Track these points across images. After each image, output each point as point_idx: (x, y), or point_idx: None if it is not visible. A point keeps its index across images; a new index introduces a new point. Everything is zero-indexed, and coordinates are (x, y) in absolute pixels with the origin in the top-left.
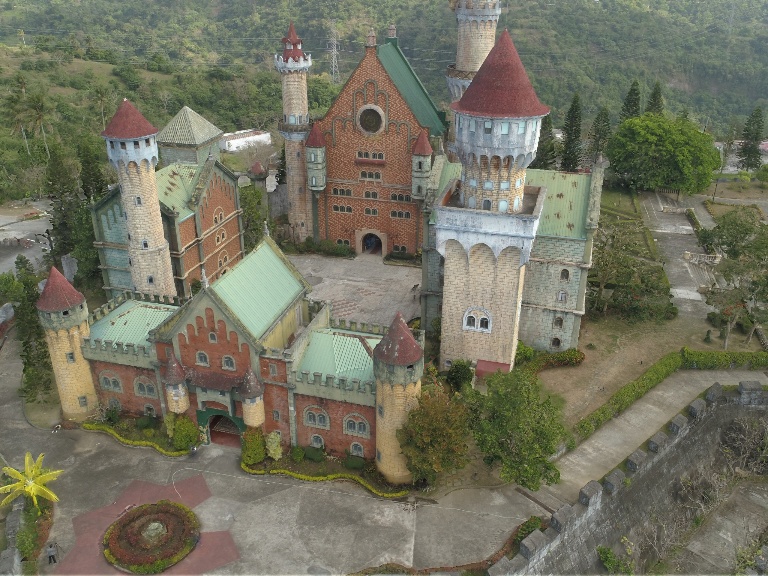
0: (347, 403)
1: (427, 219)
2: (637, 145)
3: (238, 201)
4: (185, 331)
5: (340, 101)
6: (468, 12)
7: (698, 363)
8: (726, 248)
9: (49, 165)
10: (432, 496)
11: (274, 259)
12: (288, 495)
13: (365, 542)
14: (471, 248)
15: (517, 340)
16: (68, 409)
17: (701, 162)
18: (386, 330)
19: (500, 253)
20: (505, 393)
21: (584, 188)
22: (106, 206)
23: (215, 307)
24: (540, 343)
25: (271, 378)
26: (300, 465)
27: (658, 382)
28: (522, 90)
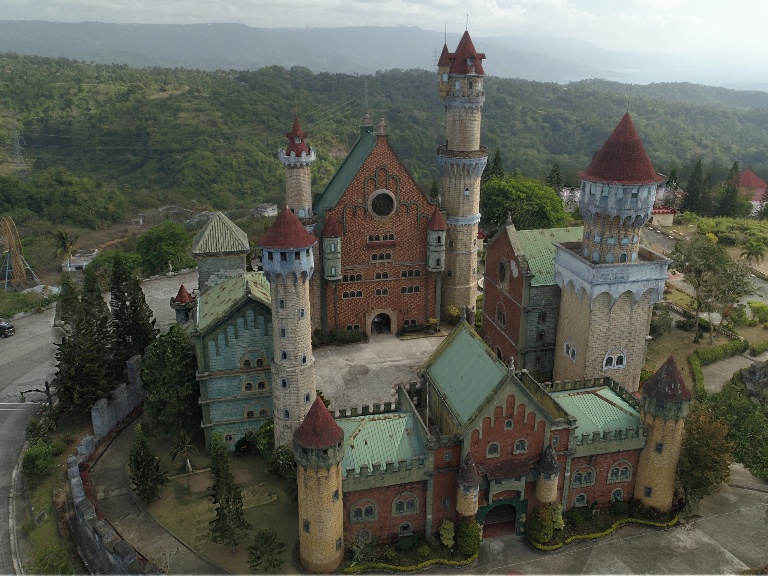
0: (616, 453)
1: (529, 282)
2: (512, 202)
3: None
4: (480, 426)
5: (351, 189)
6: (465, 100)
7: (708, 359)
8: (681, 269)
9: (61, 301)
10: (693, 512)
11: None
12: (600, 556)
13: (700, 566)
14: None
15: None
16: (322, 559)
17: (557, 210)
18: (578, 384)
19: None
20: None
21: None
22: (217, 330)
23: (518, 392)
24: None
25: None
26: (579, 527)
27: None
28: None
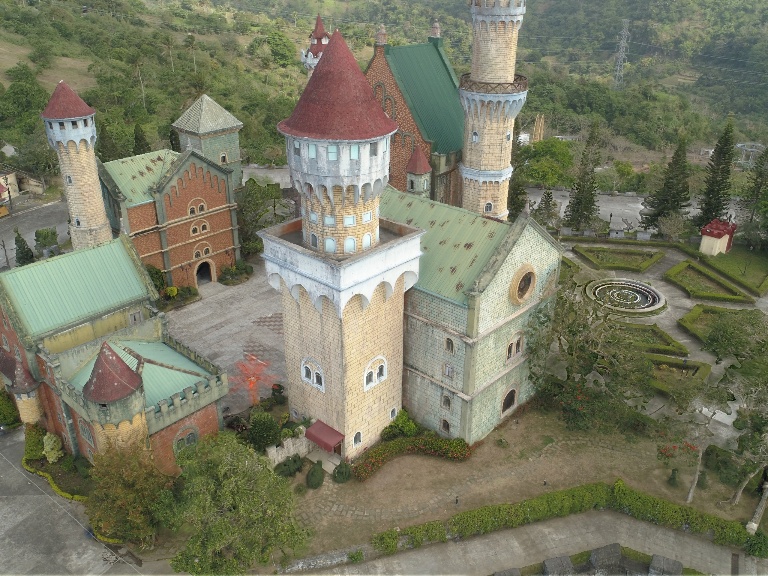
0: None
1: None
2: None
3: (231, 195)
4: None
5: None
6: (476, 10)
7: (631, 508)
8: None
9: (100, 138)
10: (143, 555)
11: (122, 258)
12: (31, 501)
13: None
14: (299, 288)
15: (397, 409)
16: None
17: None
18: (199, 359)
19: (323, 301)
20: (207, 467)
21: (499, 241)
22: None
23: None
24: (430, 421)
25: (49, 378)
26: (68, 475)
27: (555, 515)
28: (340, 106)
